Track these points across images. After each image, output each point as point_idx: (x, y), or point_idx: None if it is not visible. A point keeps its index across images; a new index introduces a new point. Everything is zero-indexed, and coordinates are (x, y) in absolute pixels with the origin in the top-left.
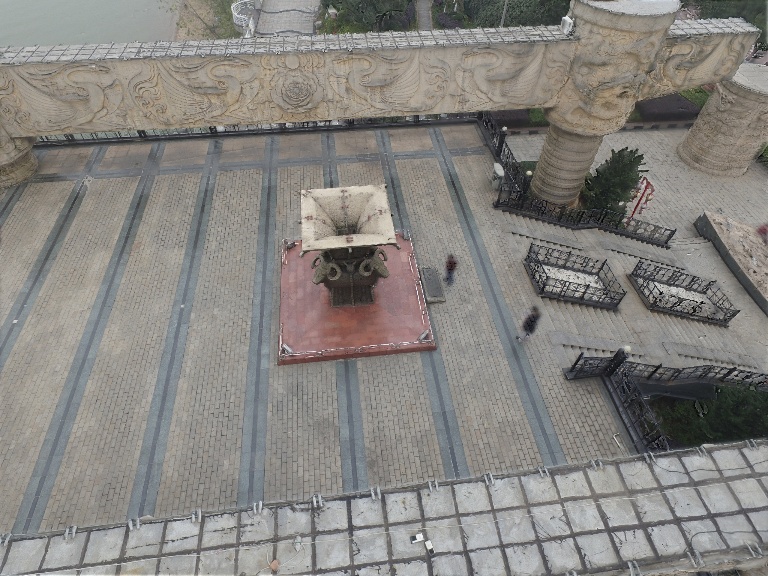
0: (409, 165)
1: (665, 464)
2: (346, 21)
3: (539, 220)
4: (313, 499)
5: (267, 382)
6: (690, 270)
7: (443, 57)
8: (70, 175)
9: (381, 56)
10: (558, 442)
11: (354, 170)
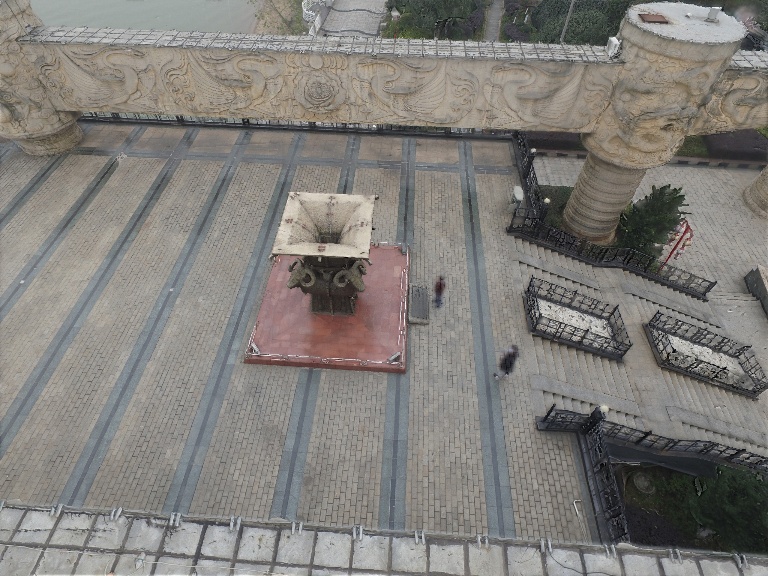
0: (429, 177)
1: (562, 557)
2: (409, 24)
3: (556, 251)
4: (171, 516)
5: (229, 378)
6: (727, 329)
7: (471, 70)
8: (107, 150)
9: (406, 63)
10: (510, 496)
11: (372, 176)
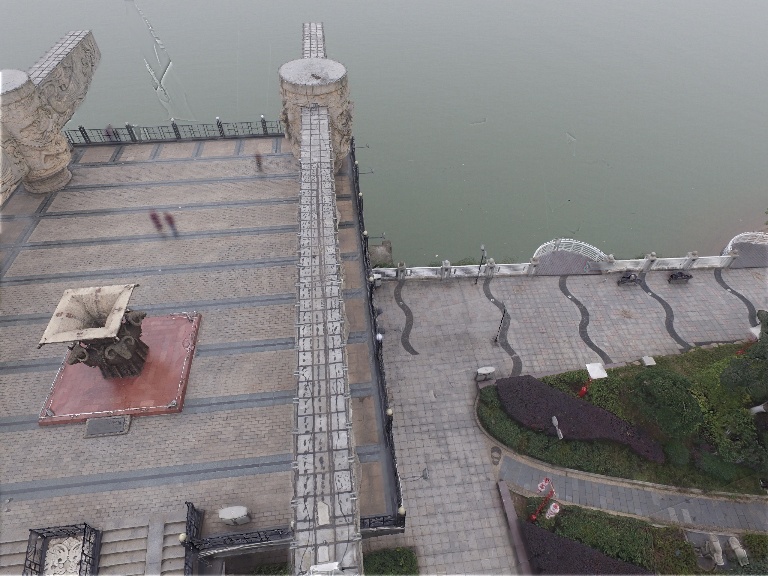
0: None
1: None
2: None
3: None
4: None
5: None
6: None
7: None
8: None
9: None
10: None
11: None
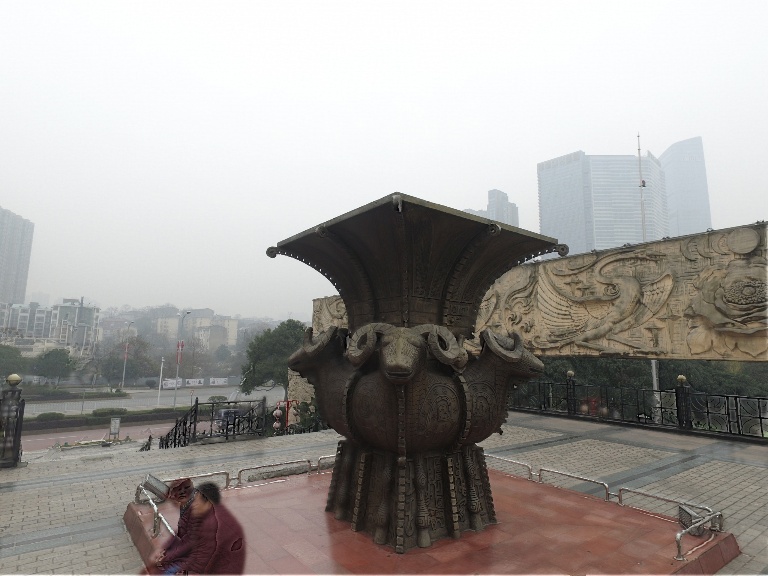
0: None
1: None
2: None
3: None
4: None
5: None
6: None
7: None
8: None
9: None
10: None
11: None
